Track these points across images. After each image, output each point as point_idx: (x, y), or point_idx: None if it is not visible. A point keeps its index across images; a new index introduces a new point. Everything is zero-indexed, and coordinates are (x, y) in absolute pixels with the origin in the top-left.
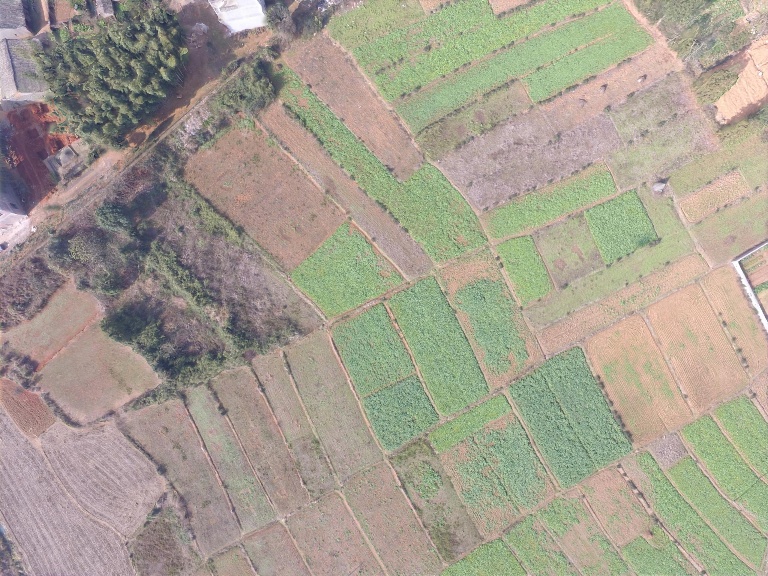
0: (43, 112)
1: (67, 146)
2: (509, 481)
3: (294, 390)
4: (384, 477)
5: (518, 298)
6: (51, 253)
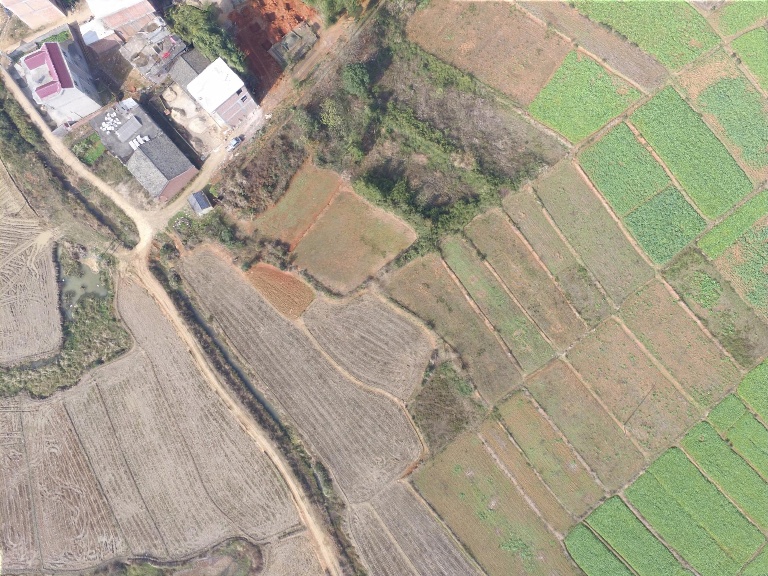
0: (262, 6)
1: (290, 31)
2: None
3: (550, 223)
4: (659, 294)
5: (763, 89)
6: (307, 117)
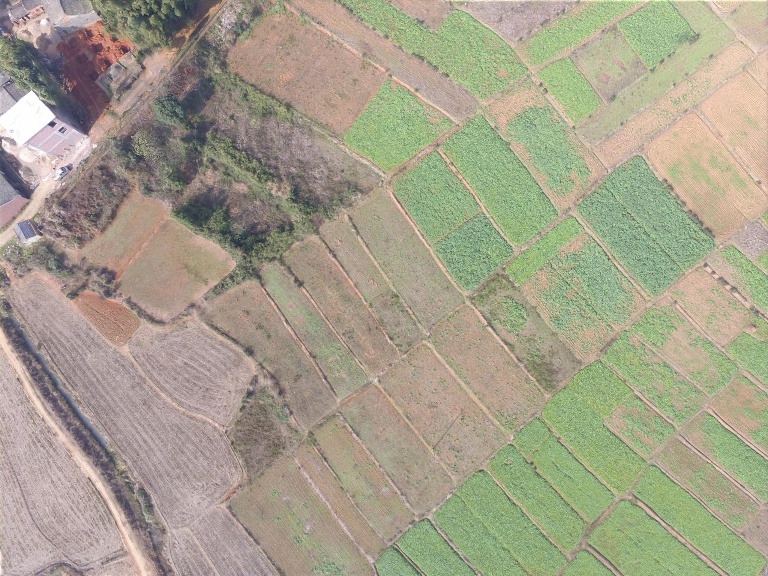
0: (89, 37)
1: (115, 62)
2: (596, 300)
3: (365, 250)
4: (469, 320)
5: (568, 119)
6: (117, 149)
